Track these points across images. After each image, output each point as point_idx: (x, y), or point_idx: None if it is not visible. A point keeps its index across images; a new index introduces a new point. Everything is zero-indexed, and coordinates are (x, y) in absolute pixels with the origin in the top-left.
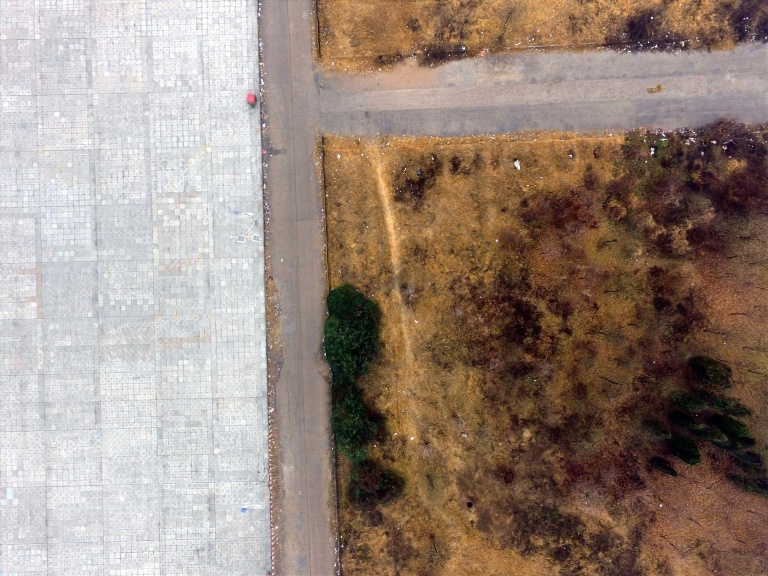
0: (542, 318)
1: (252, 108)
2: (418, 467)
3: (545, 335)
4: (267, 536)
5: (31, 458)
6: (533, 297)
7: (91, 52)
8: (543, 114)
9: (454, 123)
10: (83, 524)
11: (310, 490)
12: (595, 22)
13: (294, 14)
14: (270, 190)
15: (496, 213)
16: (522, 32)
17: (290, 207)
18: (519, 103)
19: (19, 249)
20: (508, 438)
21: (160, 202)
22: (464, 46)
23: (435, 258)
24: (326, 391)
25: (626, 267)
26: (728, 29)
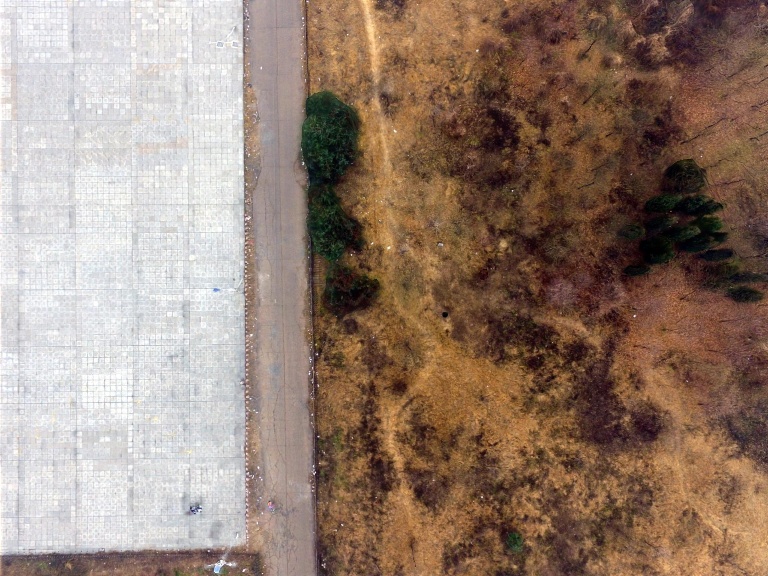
0: (521, 128)
1: None
2: (394, 277)
3: (523, 145)
4: (241, 343)
5: (4, 261)
6: (512, 108)
7: None
8: None
9: None
10: (56, 328)
11: (286, 298)
12: None
13: None
14: None
15: (477, 23)
16: None
17: (270, 14)
18: None
19: None
20: (484, 248)
21: (139, 5)
22: None
23: (415, 67)
24: (303, 200)
25: (605, 79)
26: None
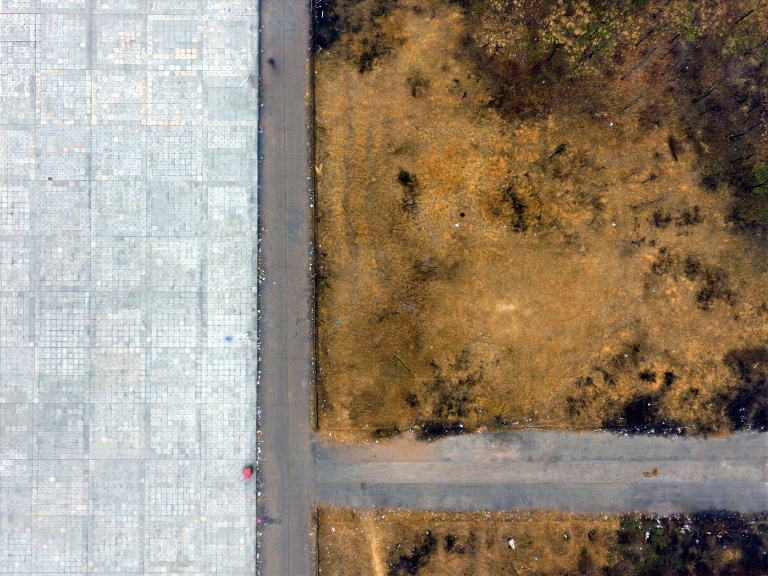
0: None
1: (248, 478)
2: None
3: None
4: None
5: None
6: None
7: (89, 417)
8: (539, 493)
9: (450, 499)
10: None
11: None
12: (593, 406)
13: (293, 383)
14: (263, 559)
15: None
16: (520, 412)
17: None
18: (515, 481)
19: None
20: None
21: (152, 571)
22: (462, 423)
23: None
24: None
25: None
26: (725, 420)
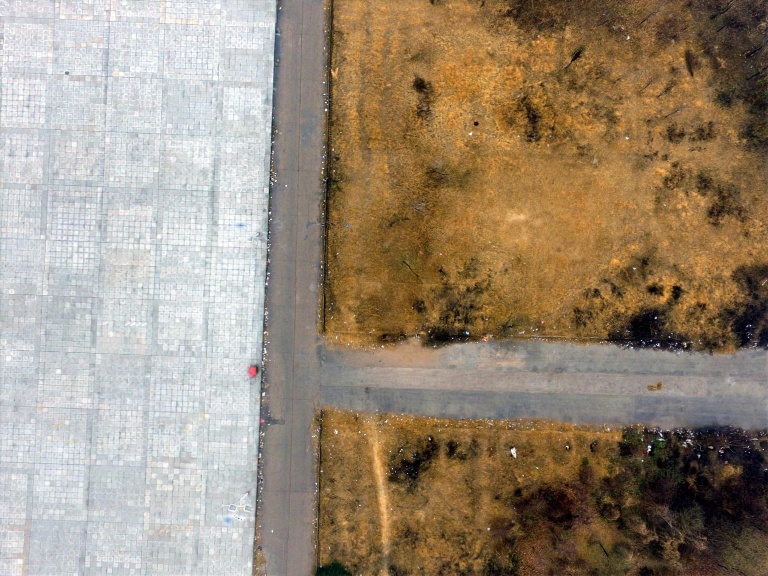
0: None
1: (253, 377)
2: None
3: None
4: None
5: None
6: None
7: (97, 311)
8: (542, 403)
9: (453, 406)
10: None
11: None
12: (599, 318)
13: (301, 285)
14: (265, 459)
15: (489, 501)
16: (526, 322)
17: (284, 478)
18: (519, 390)
19: (10, 504)
20: None
21: (154, 466)
22: (468, 331)
23: (426, 541)
24: None
25: (616, 566)
26: (731, 336)
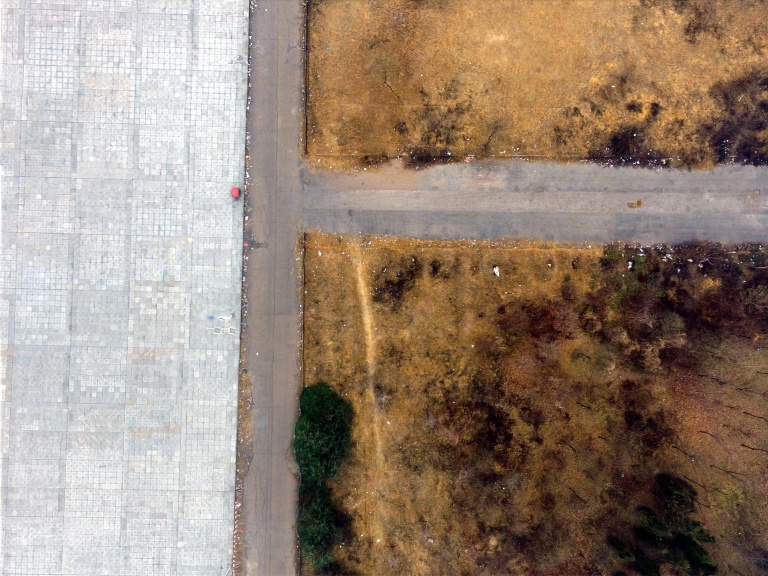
0: (514, 426)
1: (236, 201)
2: (383, 570)
3: (516, 443)
4: None
5: None
6: (506, 404)
7: (77, 136)
8: (524, 222)
9: (436, 226)
10: None
11: None
12: (579, 136)
13: (283, 109)
14: (249, 283)
15: (473, 318)
16: (507, 141)
17: (268, 301)
18: (501, 210)
19: None
20: (474, 545)
21: (138, 290)
22: (450, 151)
23: (410, 360)
24: (294, 488)
25: (599, 379)
26: (708, 150)
